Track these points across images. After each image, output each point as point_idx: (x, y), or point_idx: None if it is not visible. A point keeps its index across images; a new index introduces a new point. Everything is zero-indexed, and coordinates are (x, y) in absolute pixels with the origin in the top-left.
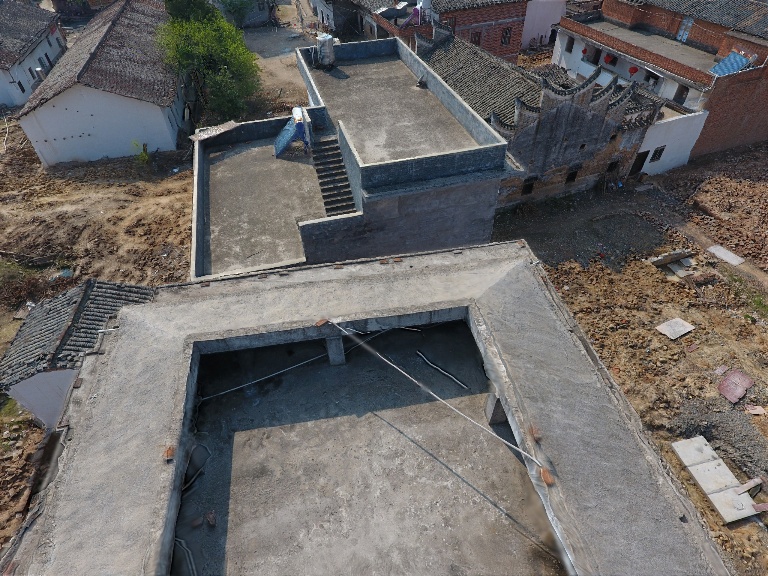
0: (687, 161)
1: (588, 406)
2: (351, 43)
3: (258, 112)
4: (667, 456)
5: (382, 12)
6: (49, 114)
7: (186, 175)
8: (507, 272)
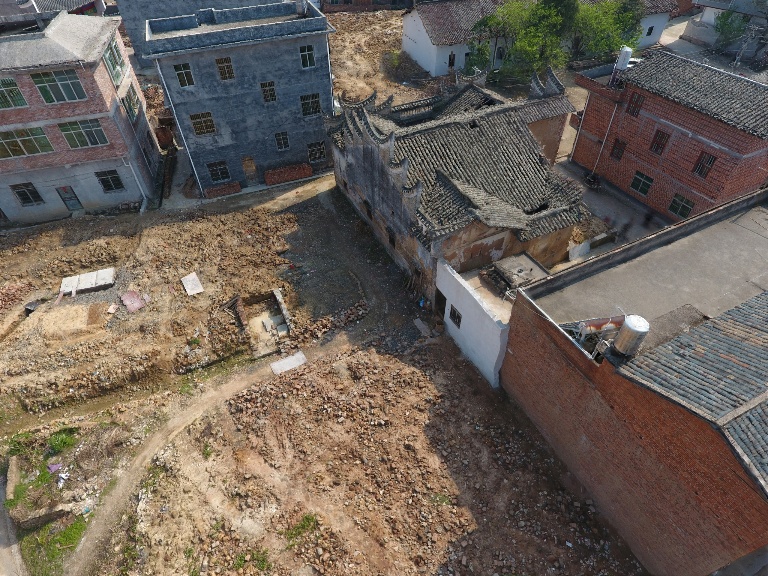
0: (494, 383)
1: (6, 58)
2: (315, 8)
3: (510, 94)
4: (110, 267)
5: (637, 62)
6: (410, 20)
7: (392, 85)
8: (69, 50)
